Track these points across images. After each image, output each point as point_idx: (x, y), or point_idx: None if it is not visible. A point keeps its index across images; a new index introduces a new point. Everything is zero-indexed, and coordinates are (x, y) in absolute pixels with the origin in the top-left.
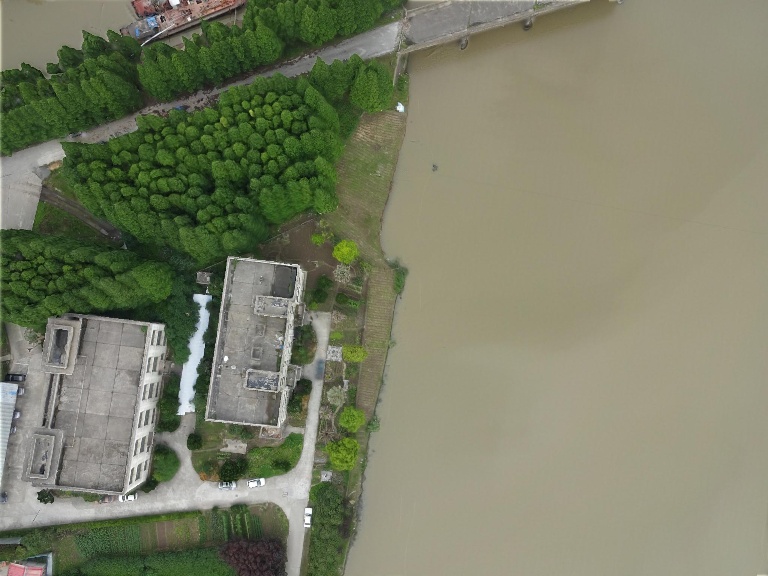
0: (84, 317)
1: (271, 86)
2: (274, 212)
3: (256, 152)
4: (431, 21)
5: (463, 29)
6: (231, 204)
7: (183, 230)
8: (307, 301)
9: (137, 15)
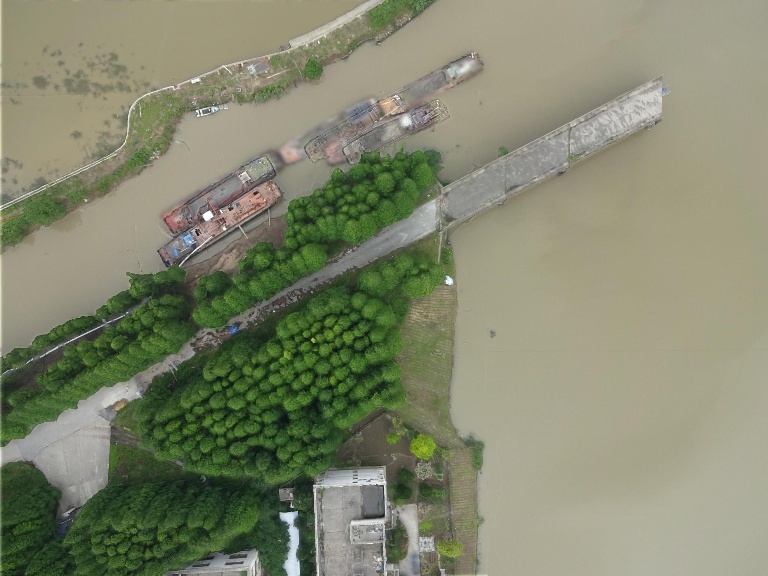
0: (183, 573)
1: (329, 311)
2: (348, 425)
3: (325, 380)
4: (468, 193)
5: (501, 195)
6: (308, 435)
7: (269, 478)
8: (391, 496)
9: (171, 231)
